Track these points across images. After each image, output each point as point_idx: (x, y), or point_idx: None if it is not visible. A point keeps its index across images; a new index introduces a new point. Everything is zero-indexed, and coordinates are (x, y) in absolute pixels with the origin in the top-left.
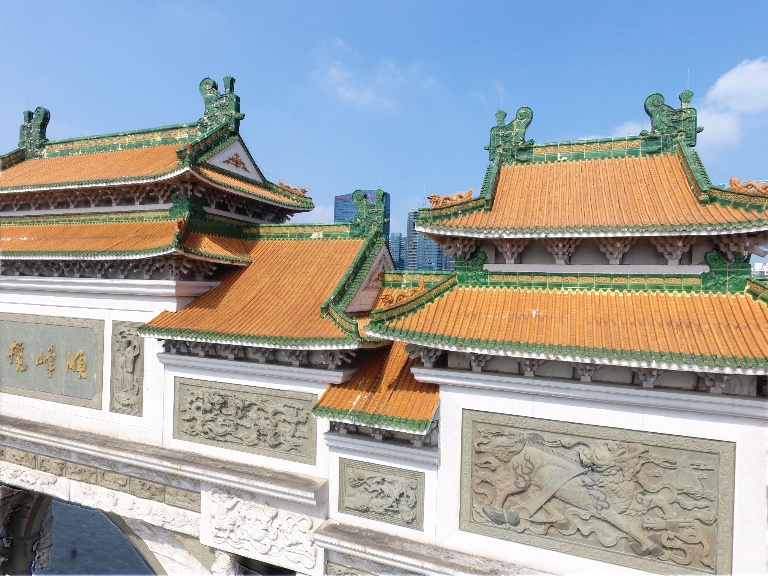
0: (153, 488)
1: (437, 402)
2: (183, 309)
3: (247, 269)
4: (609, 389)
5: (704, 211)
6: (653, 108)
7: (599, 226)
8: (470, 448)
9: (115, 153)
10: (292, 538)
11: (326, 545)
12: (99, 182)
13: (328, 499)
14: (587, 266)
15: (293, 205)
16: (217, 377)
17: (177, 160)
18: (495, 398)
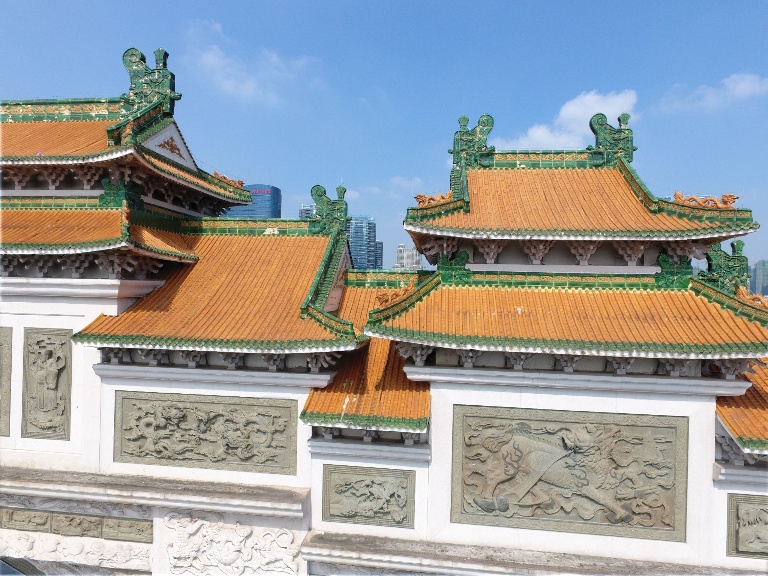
0: (86, 522)
1: (430, 400)
2: (125, 312)
3: (195, 267)
4: (591, 377)
5: (656, 219)
6: (598, 126)
7: (577, 230)
8: (461, 442)
9: (5, 125)
10: (270, 556)
11: (314, 557)
12: (2, 160)
13: (310, 509)
14: (561, 266)
15: (232, 198)
16: (173, 388)
17: (107, 140)
18: (485, 392)
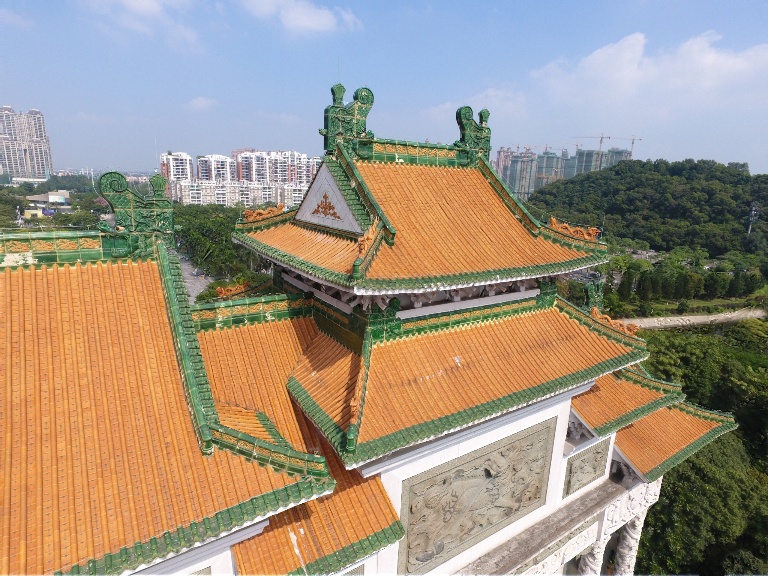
0: None
1: None
2: None
3: None
4: (515, 414)
5: None
6: (466, 121)
7: (506, 271)
8: (407, 513)
9: None
10: None
11: None
12: None
13: None
14: (476, 300)
15: None
16: None
17: None
18: (431, 456)
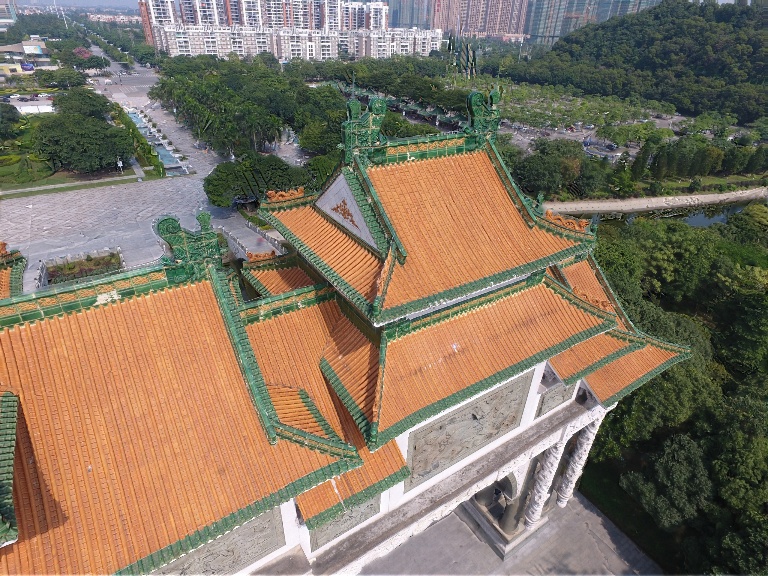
0: None
1: (396, 443)
2: None
3: (25, 415)
4: None
5: (534, 236)
6: (476, 107)
7: (499, 275)
8: (412, 450)
9: None
10: None
11: None
12: None
13: None
14: None
15: None
16: None
17: None
18: None
